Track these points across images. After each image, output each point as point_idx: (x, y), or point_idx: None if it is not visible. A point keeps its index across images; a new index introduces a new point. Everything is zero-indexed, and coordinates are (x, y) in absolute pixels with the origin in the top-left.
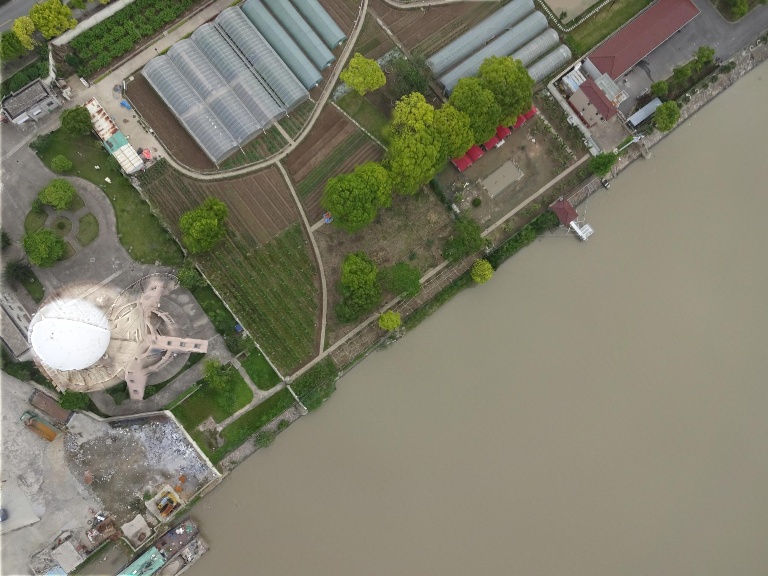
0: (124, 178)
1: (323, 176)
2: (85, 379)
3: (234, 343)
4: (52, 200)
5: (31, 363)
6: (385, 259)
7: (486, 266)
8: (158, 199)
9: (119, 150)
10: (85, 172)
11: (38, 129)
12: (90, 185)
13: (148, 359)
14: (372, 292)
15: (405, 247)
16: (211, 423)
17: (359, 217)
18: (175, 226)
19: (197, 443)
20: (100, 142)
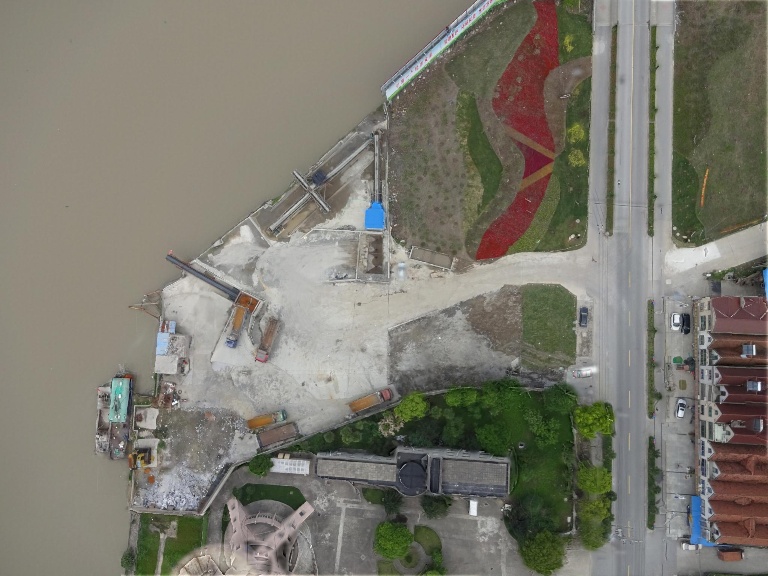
0: None
1: None
2: (187, 572)
3: None
4: None
5: None
6: None
7: None
8: None
9: None
10: None
11: None
12: None
13: None
14: None
15: None
16: (171, 533)
17: None
18: None
19: None
20: None
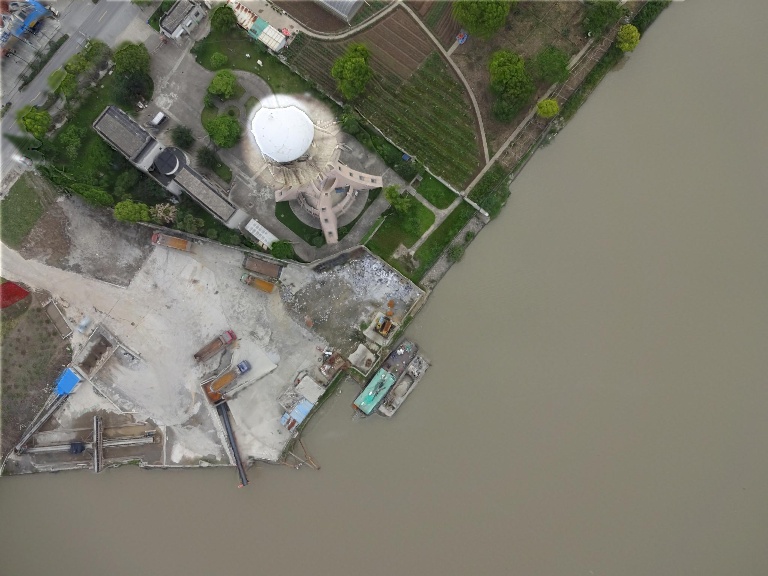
0: (273, 56)
1: (446, 2)
2: (299, 178)
3: (407, 166)
4: (220, 87)
5: (237, 231)
6: (526, 58)
7: (631, 28)
8: (305, 67)
9: (263, 33)
10: (239, 64)
11: (192, 41)
12: (245, 74)
13: (336, 193)
14: (525, 80)
15: (542, 44)
16: (403, 249)
17: (494, 13)
18: (326, 86)
19: (396, 269)
20: (245, 32)
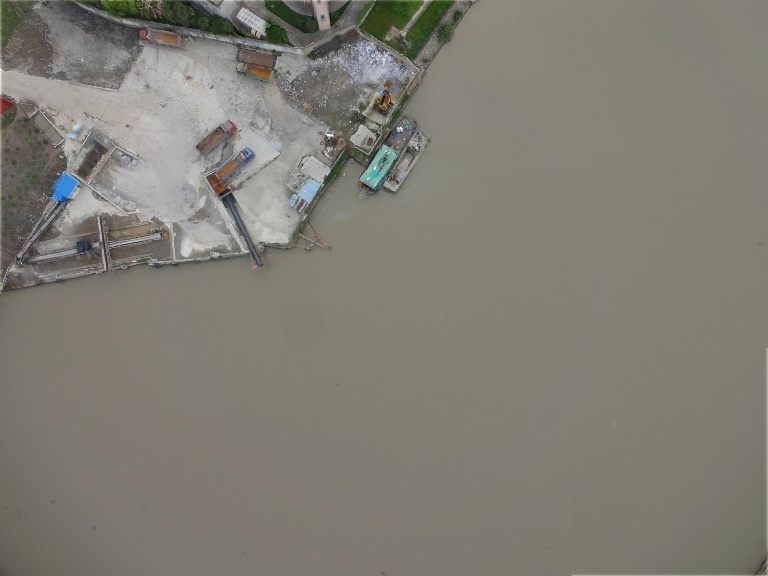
0: None
1: None
2: None
3: None
4: None
5: (228, 21)
6: None
7: None
8: None
9: None
10: None
11: None
12: None
13: None
14: None
15: None
16: (395, 32)
17: None
18: None
19: None
20: None
